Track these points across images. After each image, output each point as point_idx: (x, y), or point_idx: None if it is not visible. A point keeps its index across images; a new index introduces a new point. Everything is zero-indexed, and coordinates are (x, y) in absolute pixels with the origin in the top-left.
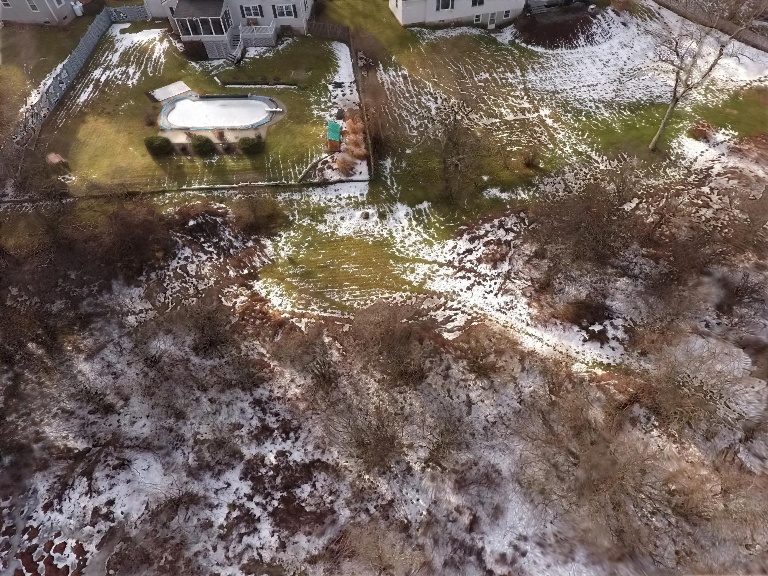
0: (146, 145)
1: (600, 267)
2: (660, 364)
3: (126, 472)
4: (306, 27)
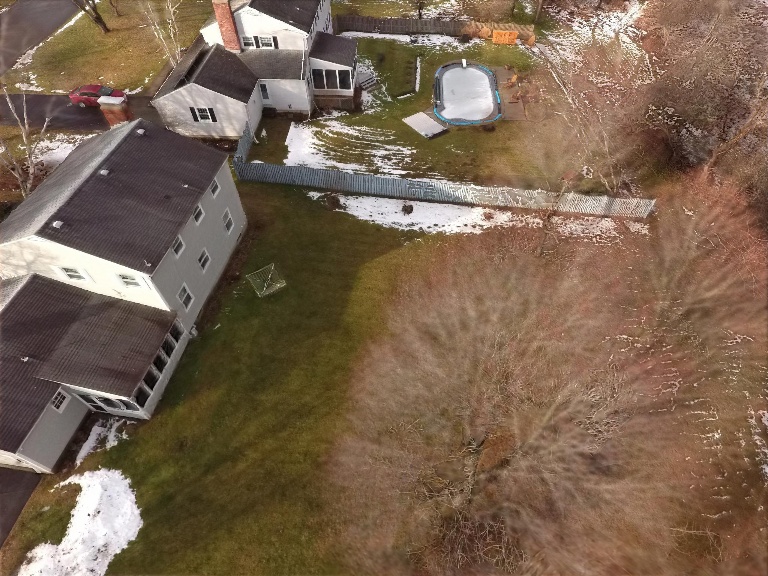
0: (545, 111)
1: None
2: None
3: None
4: (332, 33)
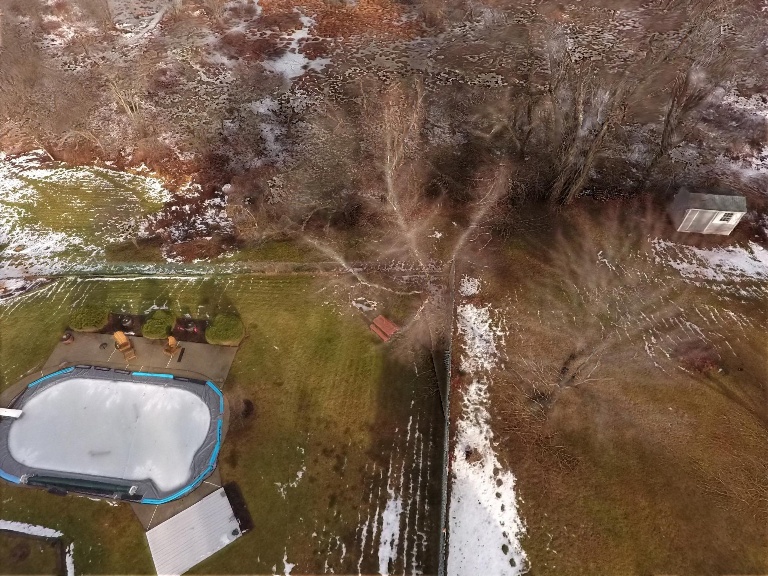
0: None
1: None
2: None
3: None
4: None
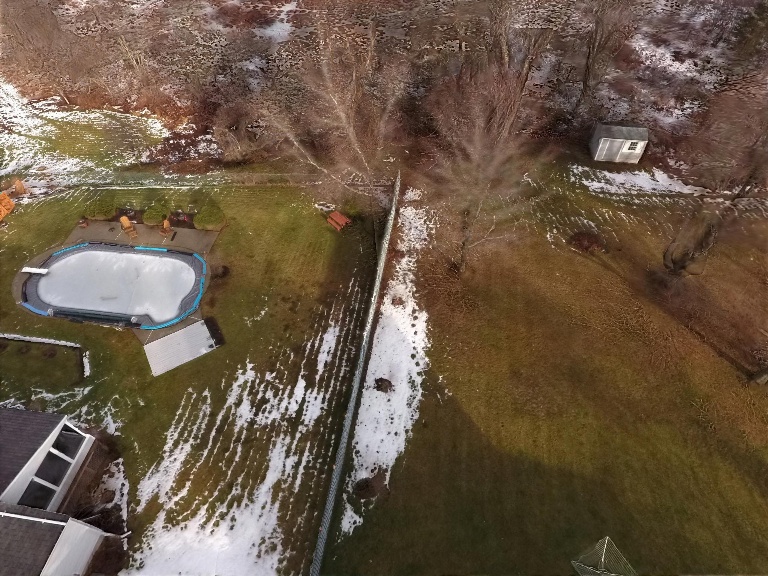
0: None
1: None
2: None
3: None
4: None
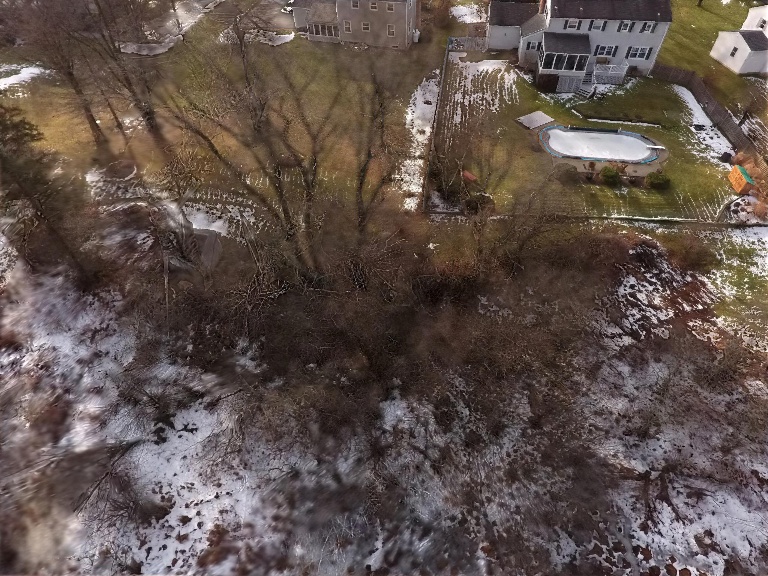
0: (560, 171)
1: None
2: None
3: (703, 502)
4: (651, 69)
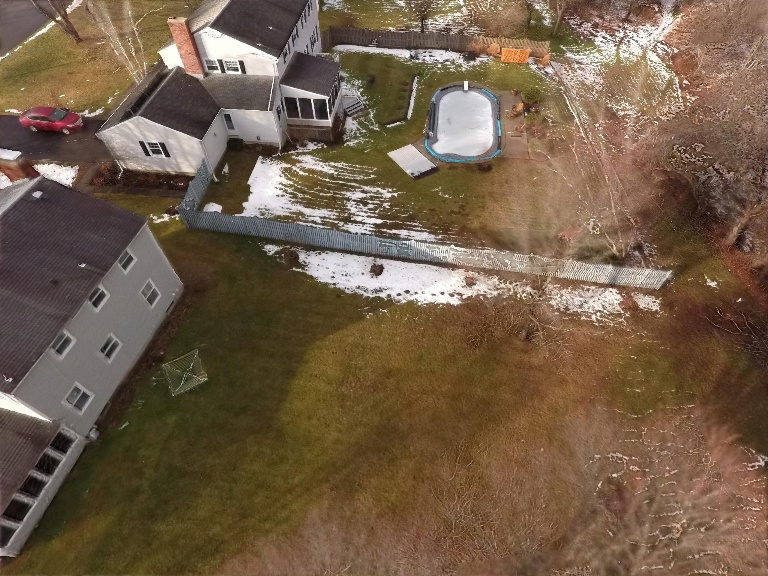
0: (550, 149)
1: (605, 5)
2: (666, 3)
3: None
4: (321, 48)
